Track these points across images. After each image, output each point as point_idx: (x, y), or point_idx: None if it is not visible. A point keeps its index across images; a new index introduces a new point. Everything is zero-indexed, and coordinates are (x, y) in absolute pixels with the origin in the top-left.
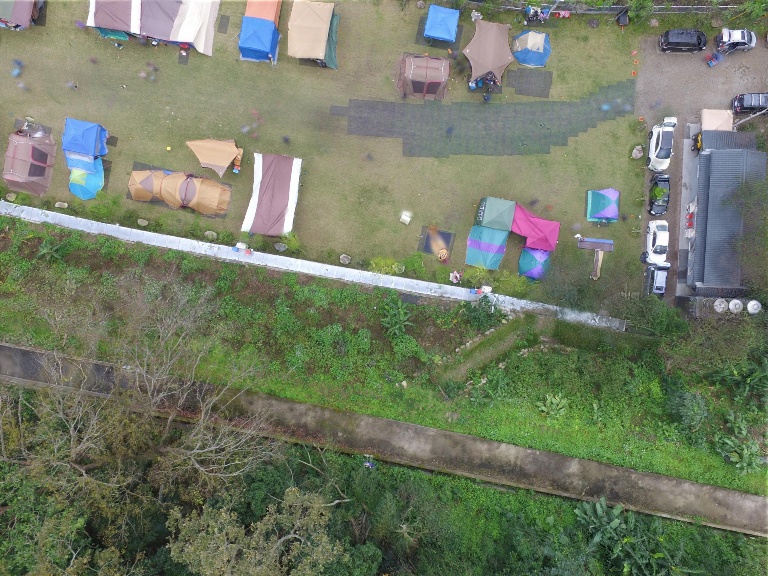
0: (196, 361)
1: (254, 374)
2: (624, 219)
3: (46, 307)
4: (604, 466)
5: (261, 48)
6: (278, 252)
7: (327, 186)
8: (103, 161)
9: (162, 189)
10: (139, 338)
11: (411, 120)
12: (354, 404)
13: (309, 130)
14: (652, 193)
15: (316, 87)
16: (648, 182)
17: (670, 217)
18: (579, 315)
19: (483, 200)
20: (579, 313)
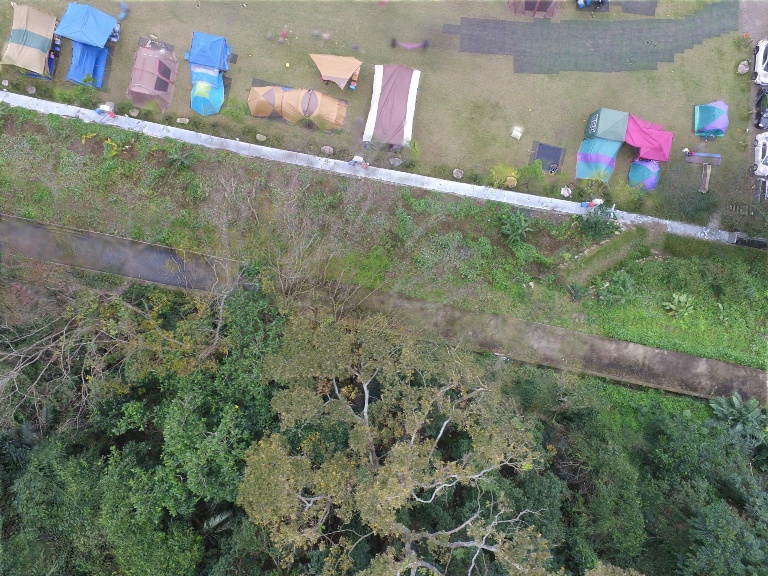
0: (327, 262)
1: (384, 274)
2: (731, 133)
3: (181, 208)
4: (732, 366)
5: None
6: (392, 167)
7: (440, 102)
8: (223, 78)
9: (283, 102)
10: (272, 239)
11: (521, 38)
12: (482, 305)
13: (423, 47)
14: (760, 106)
15: (429, 6)
16: (754, 97)
17: None
18: (689, 228)
19: (595, 113)
20: (689, 226)
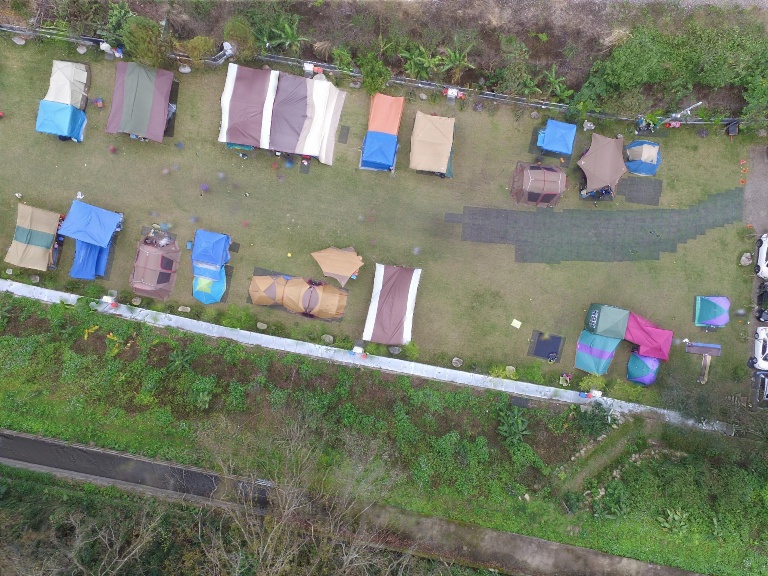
0: (325, 474)
1: (381, 487)
2: (732, 324)
3: (181, 420)
4: None
5: (384, 162)
6: (392, 355)
7: (441, 291)
8: (225, 267)
9: (284, 296)
10: (270, 451)
11: (524, 227)
12: (478, 517)
13: (424, 237)
14: (762, 301)
15: (432, 195)
16: (756, 288)
17: None
18: (686, 419)
19: (596, 307)
20: (687, 417)
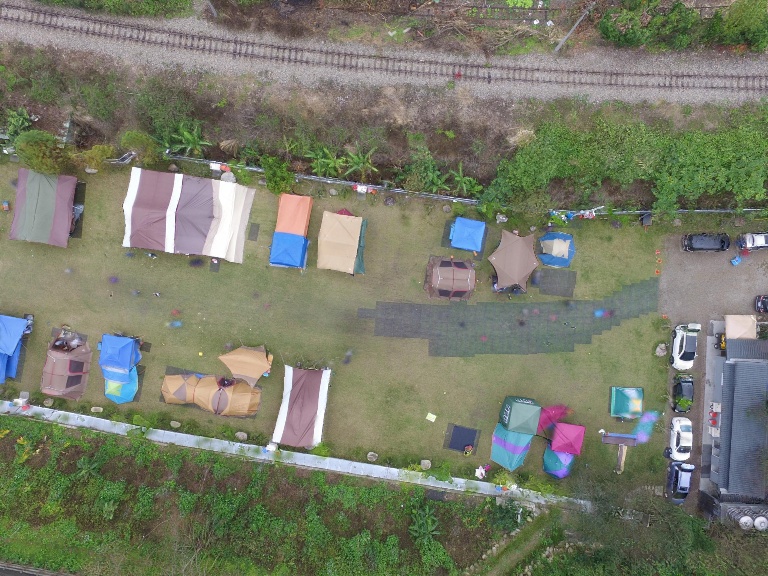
0: None
1: None
2: (648, 415)
3: (85, 532)
4: None
5: (291, 263)
6: (307, 450)
7: (355, 386)
8: (137, 366)
9: (195, 398)
10: (175, 561)
11: (437, 321)
12: None
13: (337, 332)
14: (676, 392)
15: (344, 291)
16: (671, 379)
17: (693, 412)
18: (603, 508)
19: (508, 402)
20: (603, 507)
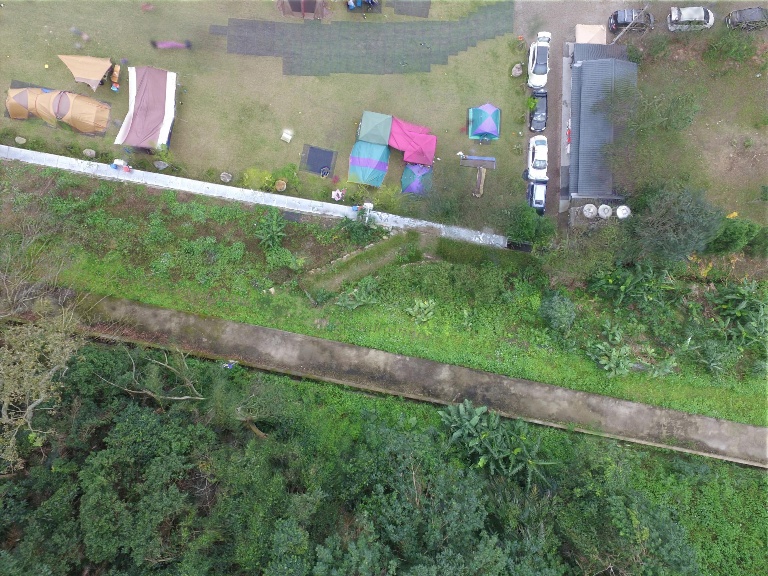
0: (59, 267)
1: (118, 280)
2: (506, 137)
3: None
4: (475, 372)
5: None
6: (158, 170)
7: (207, 104)
8: None
9: (37, 104)
10: (1, 244)
11: (291, 39)
12: (221, 311)
13: (188, 49)
14: (531, 109)
15: (195, 6)
16: None
17: (551, 134)
18: (463, 233)
19: (361, 116)
20: (463, 231)
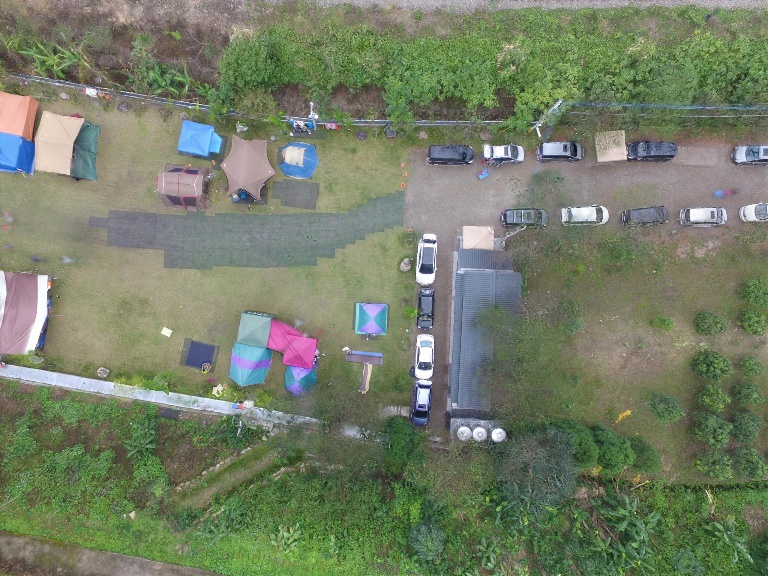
0: None
1: None
2: (393, 332)
3: None
4: None
5: (6, 163)
6: (34, 365)
7: (85, 298)
8: None
9: None
10: None
11: (173, 231)
12: (79, 536)
13: (66, 241)
14: (418, 308)
15: (74, 198)
16: (417, 295)
17: (440, 330)
18: (347, 430)
19: None
20: (347, 428)
